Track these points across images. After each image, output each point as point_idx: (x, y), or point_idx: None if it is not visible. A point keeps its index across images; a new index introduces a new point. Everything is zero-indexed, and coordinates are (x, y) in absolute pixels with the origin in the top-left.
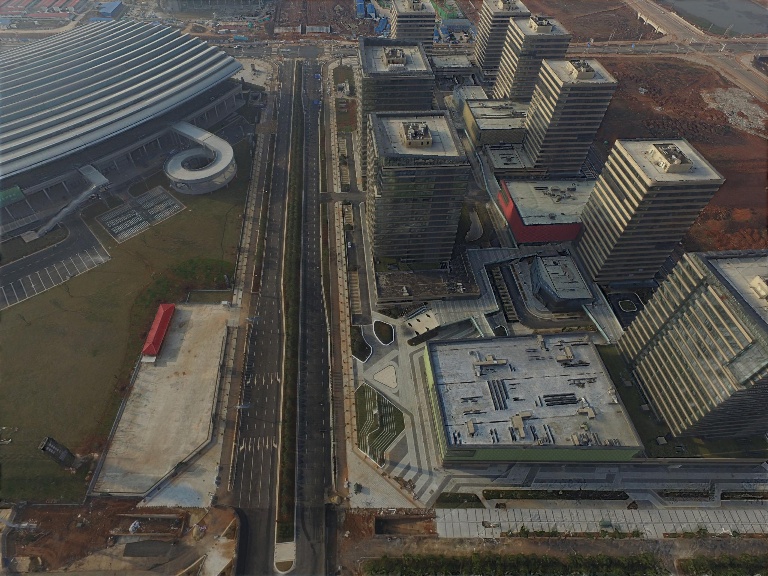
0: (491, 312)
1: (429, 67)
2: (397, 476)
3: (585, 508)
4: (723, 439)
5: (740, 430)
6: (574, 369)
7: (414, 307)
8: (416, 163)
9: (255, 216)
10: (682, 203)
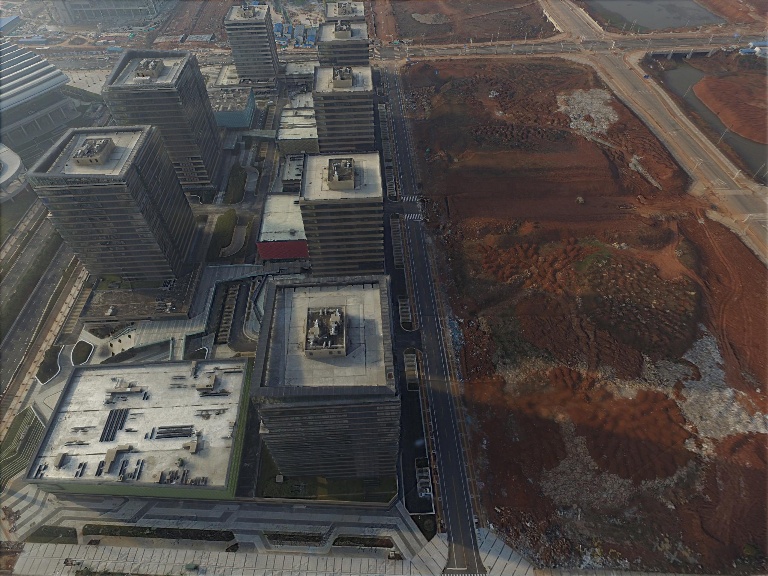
0: (195, 333)
1: (174, 79)
2: (7, 506)
3: (181, 548)
4: (348, 479)
5: (355, 471)
6: (210, 399)
7: (121, 327)
8: (71, 182)
9: (25, 231)
10: (352, 222)
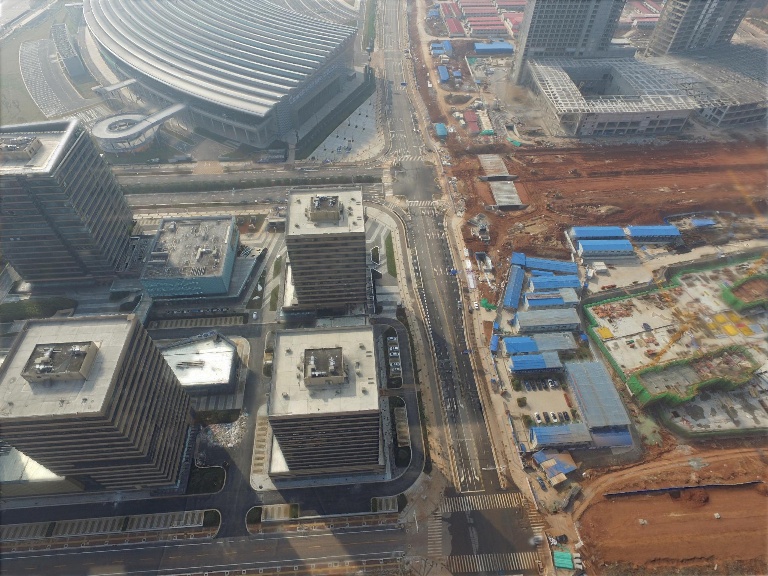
0: None
1: None
2: None
3: None
4: None
5: None
6: None
7: None
8: None
9: None
10: None
